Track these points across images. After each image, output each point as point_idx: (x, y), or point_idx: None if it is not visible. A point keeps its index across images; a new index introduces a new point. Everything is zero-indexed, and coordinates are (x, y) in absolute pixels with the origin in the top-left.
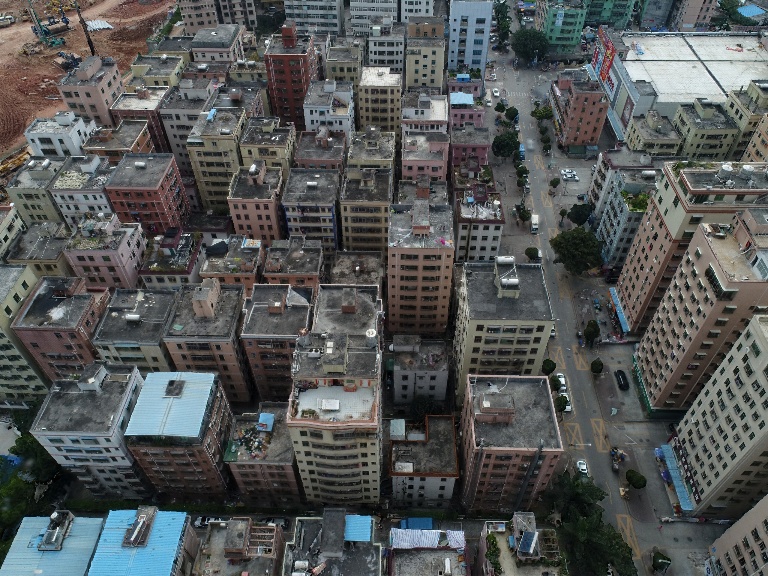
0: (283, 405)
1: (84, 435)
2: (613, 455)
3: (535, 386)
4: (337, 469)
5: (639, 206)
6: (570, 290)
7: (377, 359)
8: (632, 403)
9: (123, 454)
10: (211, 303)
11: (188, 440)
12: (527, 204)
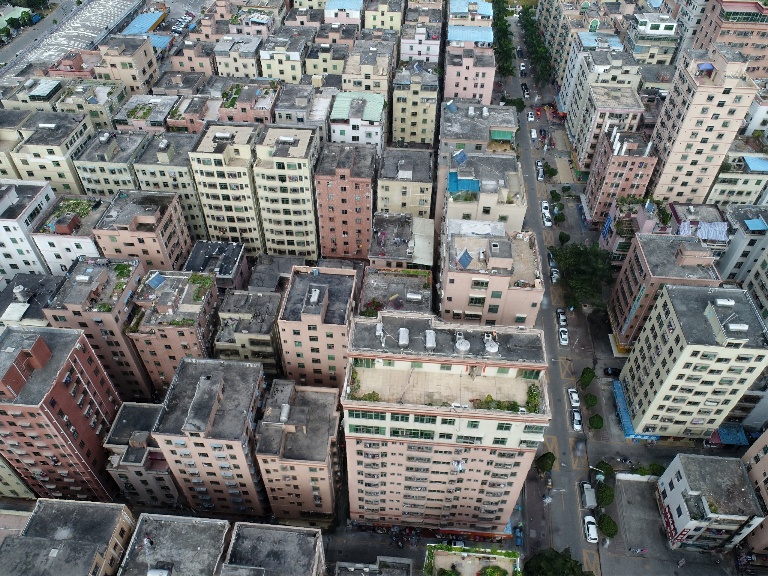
0: None
1: None
2: None
3: None
4: None
5: (498, 569)
6: None
7: None
8: None
9: None
10: None
11: None
12: None
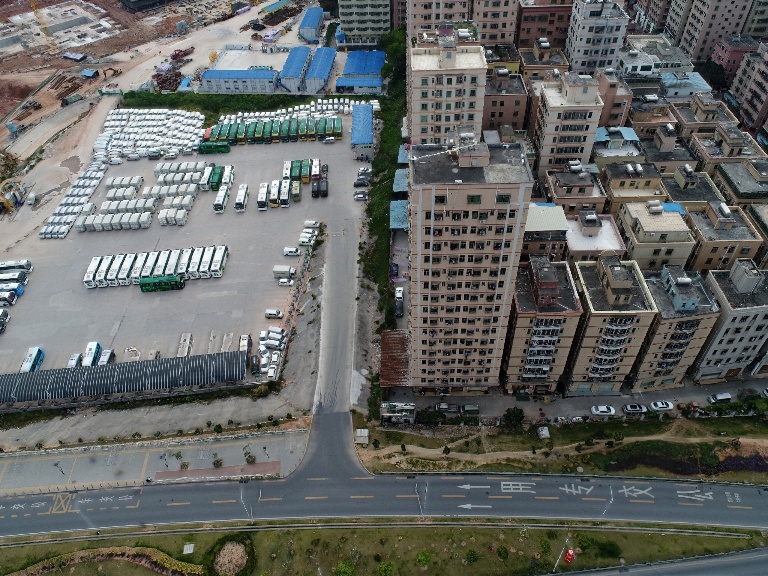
0: None
1: None
2: None
3: None
4: None
5: None
6: None
7: None
8: None
9: None
10: None
11: None
12: None
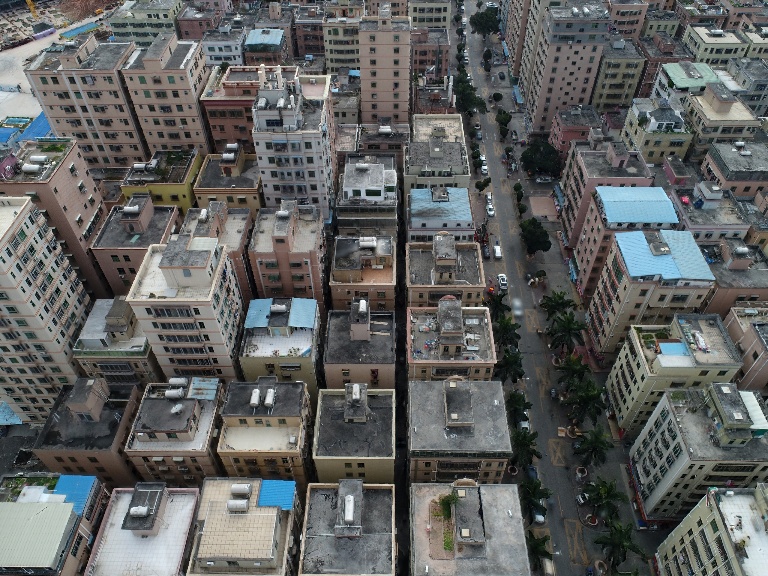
0: (317, 55)
1: (226, 44)
2: (490, 97)
3: (441, 33)
4: (345, 64)
5: None
6: (481, 48)
7: (363, 2)
8: (505, 83)
9: (241, 62)
10: (278, 11)
11: (274, 51)
12: (462, 17)
